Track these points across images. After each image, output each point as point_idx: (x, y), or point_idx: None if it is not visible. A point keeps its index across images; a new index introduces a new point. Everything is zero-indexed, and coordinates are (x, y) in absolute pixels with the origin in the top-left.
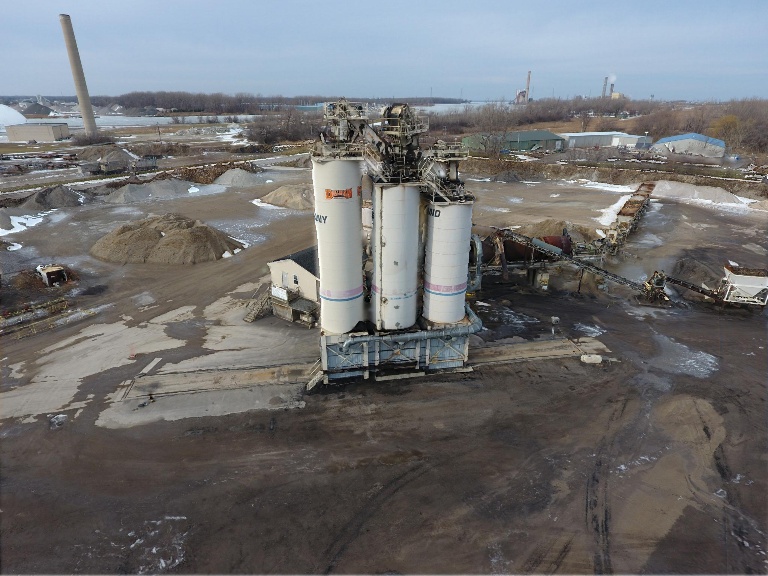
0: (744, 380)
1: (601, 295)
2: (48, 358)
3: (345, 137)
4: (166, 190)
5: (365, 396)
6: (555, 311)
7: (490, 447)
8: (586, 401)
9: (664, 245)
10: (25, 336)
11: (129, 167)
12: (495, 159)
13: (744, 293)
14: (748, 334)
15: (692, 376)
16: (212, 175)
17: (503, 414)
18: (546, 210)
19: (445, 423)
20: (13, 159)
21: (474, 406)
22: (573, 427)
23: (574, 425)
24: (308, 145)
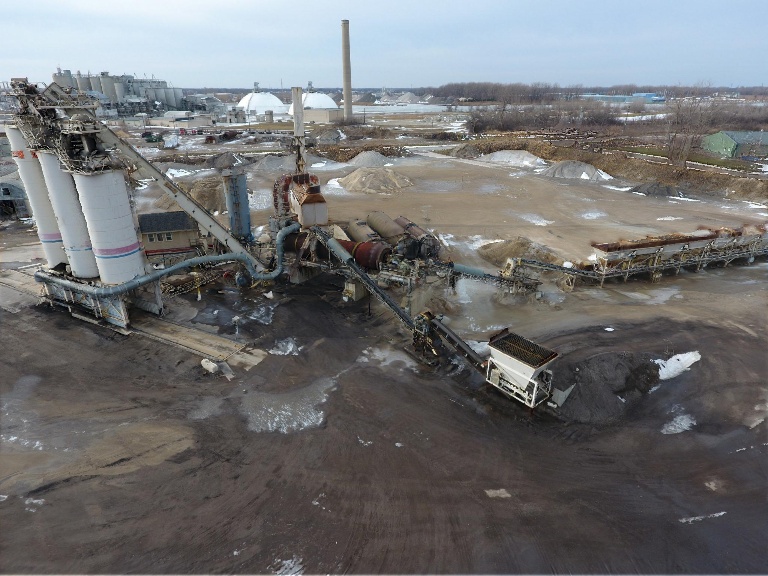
0: (276, 454)
1: (390, 325)
2: (13, 248)
3: (23, 110)
4: (294, 163)
5: (46, 321)
6: (304, 321)
7: (6, 380)
8: (121, 390)
9: (650, 305)
10: (32, 235)
11: (317, 144)
12: (680, 165)
13: (511, 378)
14: (428, 426)
15: (245, 423)
16: (349, 155)
17: (64, 368)
18: (582, 230)
19: (30, 355)
20: (272, 133)
21: (66, 355)
22: (67, 399)
23: (71, 398)
24: (509, 135)
